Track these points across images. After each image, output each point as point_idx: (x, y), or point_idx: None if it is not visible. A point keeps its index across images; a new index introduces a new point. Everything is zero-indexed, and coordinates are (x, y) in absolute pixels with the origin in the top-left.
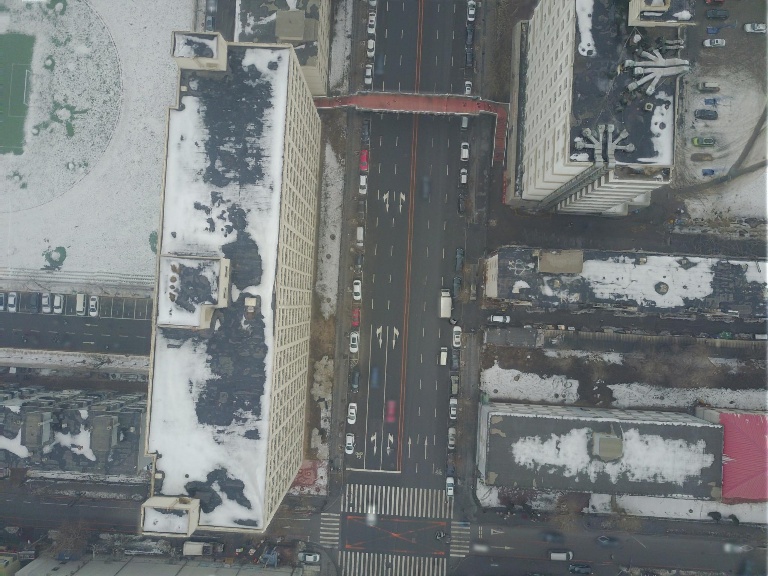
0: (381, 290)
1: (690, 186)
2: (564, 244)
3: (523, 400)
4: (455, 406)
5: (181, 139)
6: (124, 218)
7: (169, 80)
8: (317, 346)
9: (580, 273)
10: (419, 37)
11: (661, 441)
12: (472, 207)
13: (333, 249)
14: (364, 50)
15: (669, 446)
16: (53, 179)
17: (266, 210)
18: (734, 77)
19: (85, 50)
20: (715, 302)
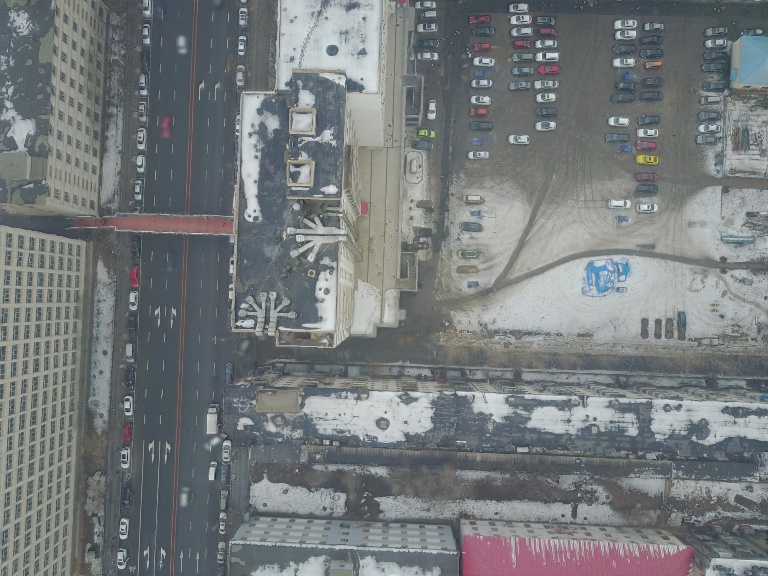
0: (153, 405)
1: (456, 298)
2: (332, 357)
3: (292, 513)
4: (224, 521)
5: None
6: None
7: None
8: (90, 462)
9: (303, 409)
10: (189, 151)
11: (397, 568)
12: None
13: (105, 365)
14: (134, 166)
15: (405, 573)
16: None
17: None
18: (499, 188)
19: None
20: (436, 437)
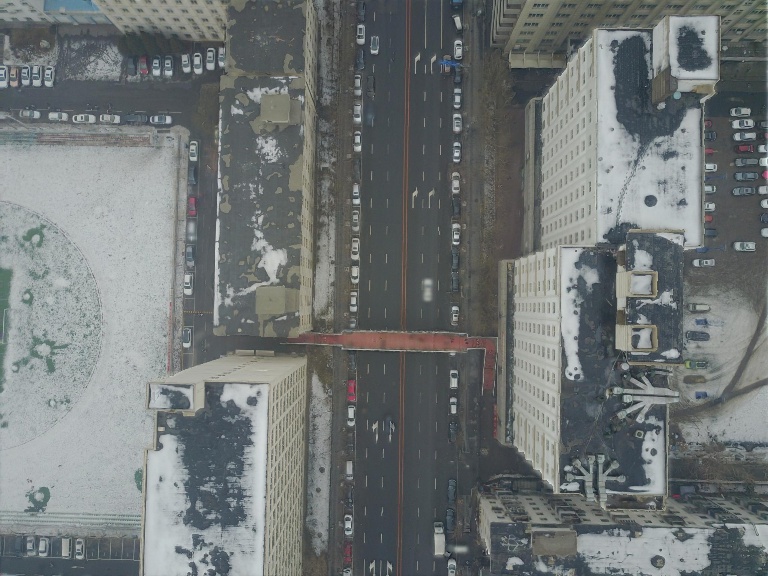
0: (373, 523)
1: (684, 409)
2: None
3: None
4: None
5: (160, 480)
6: (108, 456)
7: (150, 312)
8: None
9: None
10: (404, 261)
11: None
12: (463, 436)
13: (323, 482)
14: (348, 276)
15: None
16: (35, 417)
17: (249, 553)
18: (725, 296)
19: (63, 283)
20: (713, 574)
